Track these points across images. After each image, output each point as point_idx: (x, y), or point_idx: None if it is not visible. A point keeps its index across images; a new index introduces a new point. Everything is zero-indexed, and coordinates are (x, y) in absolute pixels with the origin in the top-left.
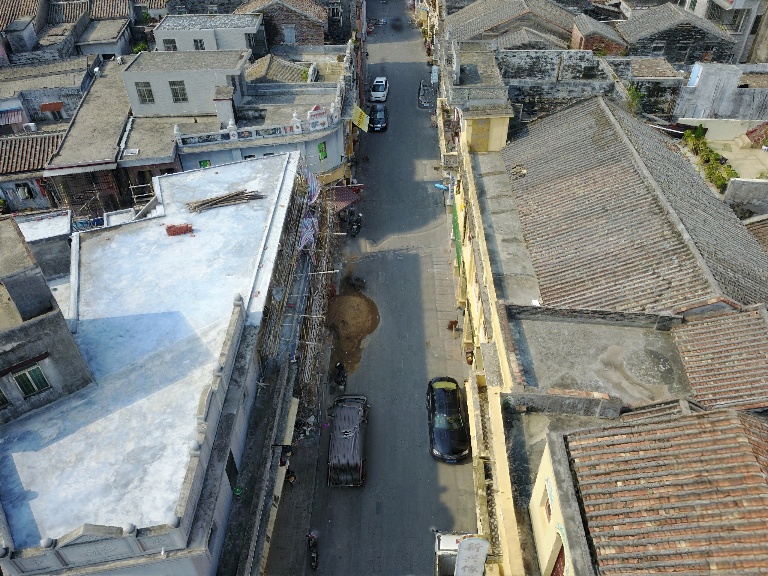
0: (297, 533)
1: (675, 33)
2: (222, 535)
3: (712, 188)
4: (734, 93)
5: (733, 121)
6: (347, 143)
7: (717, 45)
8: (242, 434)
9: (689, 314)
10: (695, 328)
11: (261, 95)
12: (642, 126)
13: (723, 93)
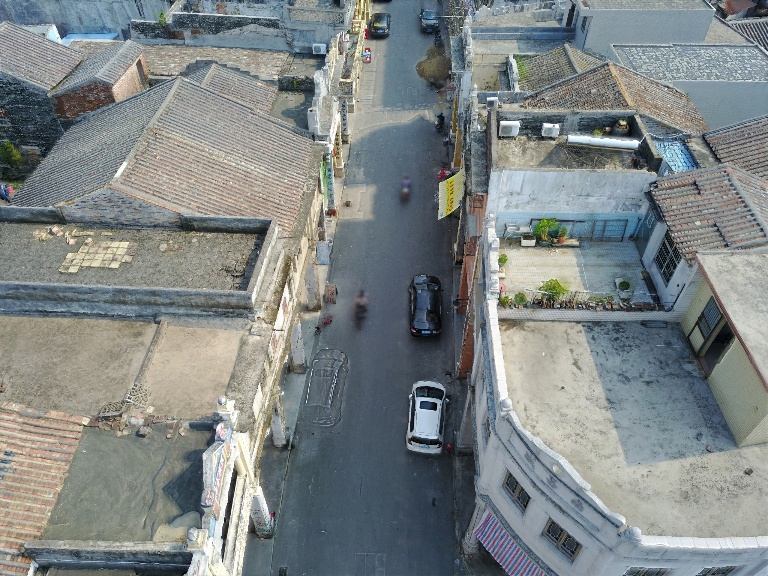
0: (448, 5)
1: None
2: None
3: None
4: None
5: None
6: None
7: None
8: None
9: None
10: None
11: None
12: None
13: None
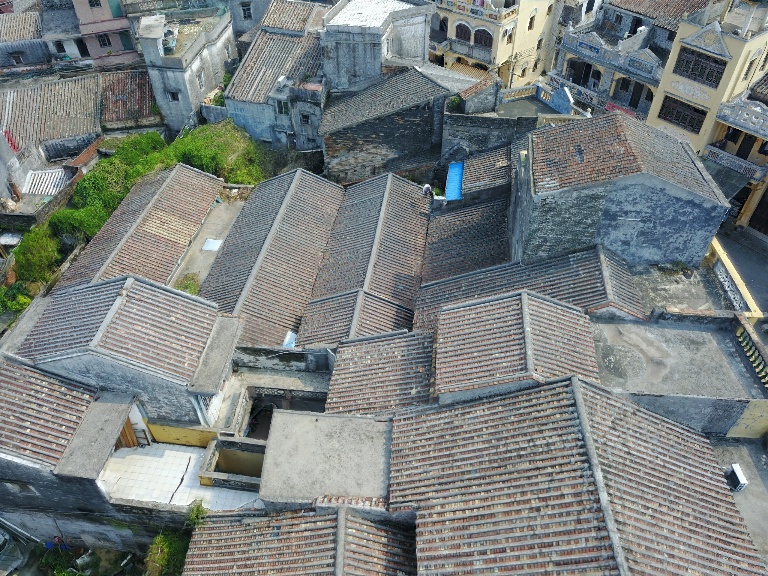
0: None
1: None
2: None
3: None
4: None
5: None
6: None
7: None
8: None
9: None
10: None
11: None
12: None
13: None
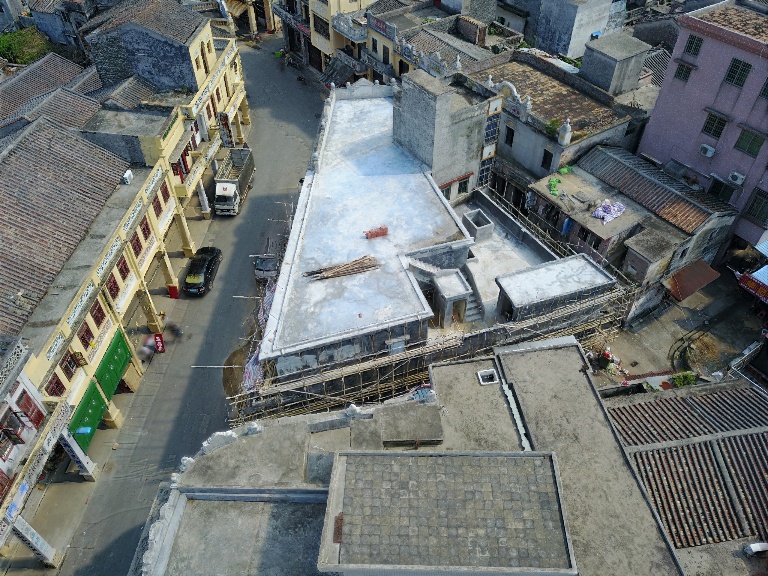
0: None
1: None
2: None
3: None
4: None
5: None
6: None
7: None
8: None
9: None
10: None
11: None
12: None
13: None
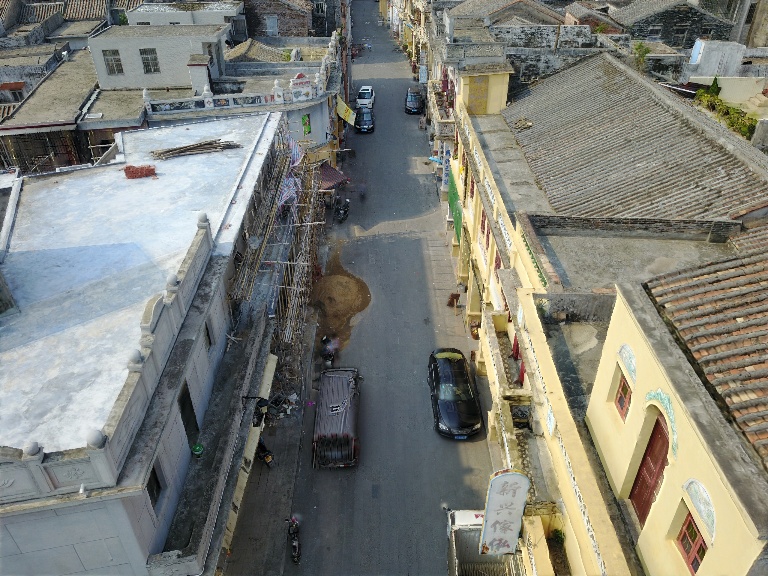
0: (274, 521)
1: (672, 15)
2: (174, 499)
3: (736, 136)
4: (738, 70)
5: (748, 79)
6: (333, 129)
7: (715, 28)
8: (206, 386)
9: (749, 219)
10: (758, 234)
11: (240, 75)
12: None
13: (727, 70)
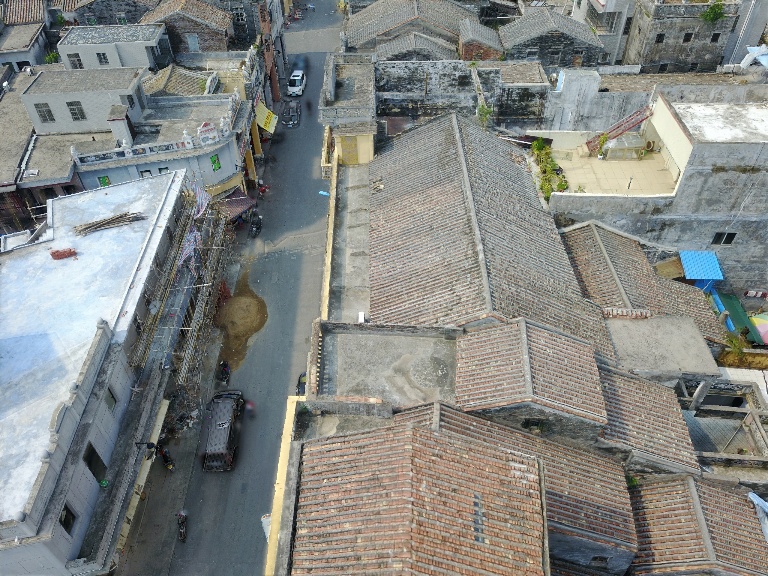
0: (172, 512)
1: (546, 39)
2: (86, 520)
3: (542, 199)
4: (596, 97)
5: (573, 133)
6: (248, 148)
7: (585, 49)
8: (111, 435)
9: (469, 326)
10: (472, 338)
11: (161, 107)
12: (492, 140)
13: (586, 97)
